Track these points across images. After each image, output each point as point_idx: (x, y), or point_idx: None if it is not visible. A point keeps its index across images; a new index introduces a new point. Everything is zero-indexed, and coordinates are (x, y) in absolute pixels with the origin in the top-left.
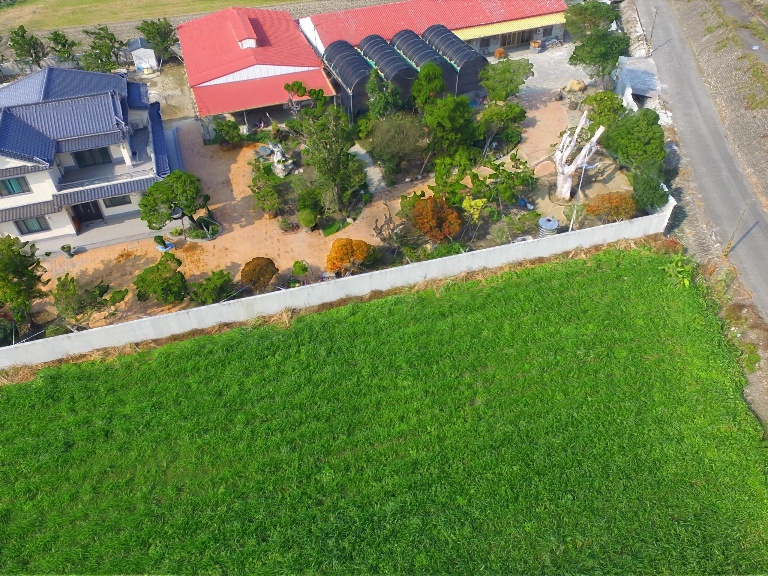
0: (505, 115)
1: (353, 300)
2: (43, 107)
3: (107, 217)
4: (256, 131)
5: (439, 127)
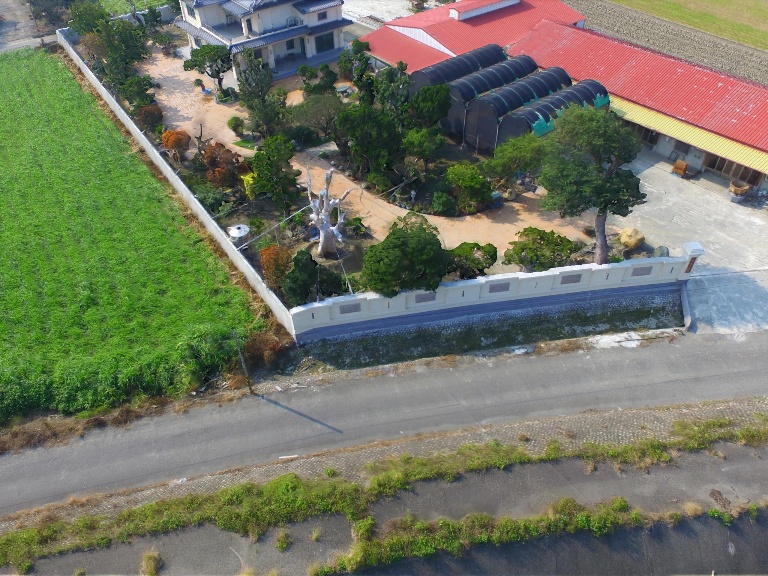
0: (461, 181)
1: (157, 171)
2: None
3: None
4: None
5: None
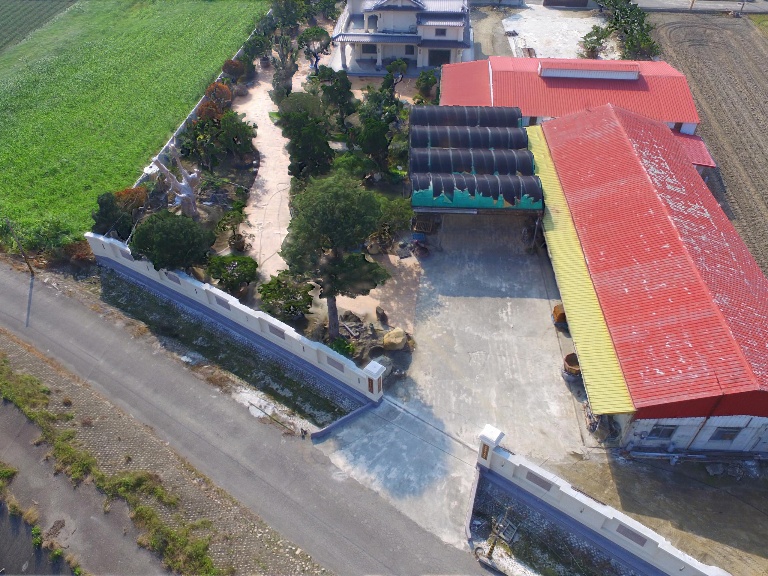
0: None
1: None
2: None
3: None
4: None
5: None
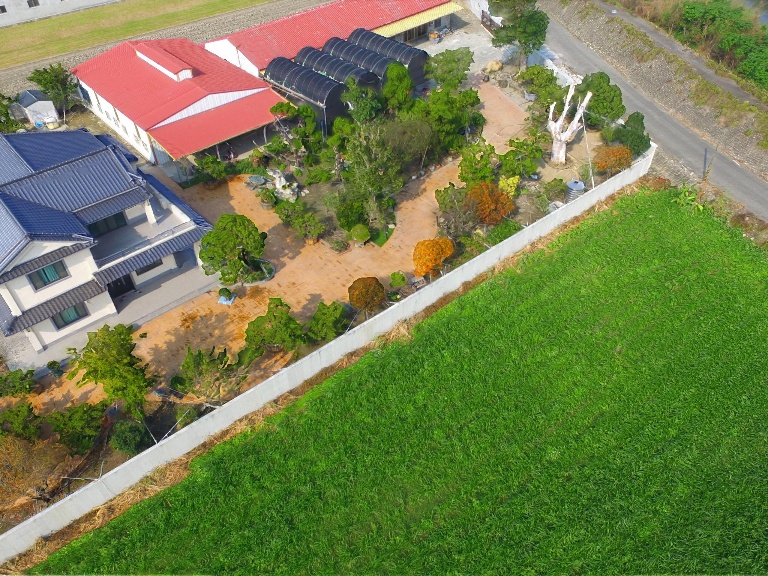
0: (465, 101)
1: (451, 297)
2: (39, 179)
3: (138, 286)
4: (231, 163)
5: (437, 121)
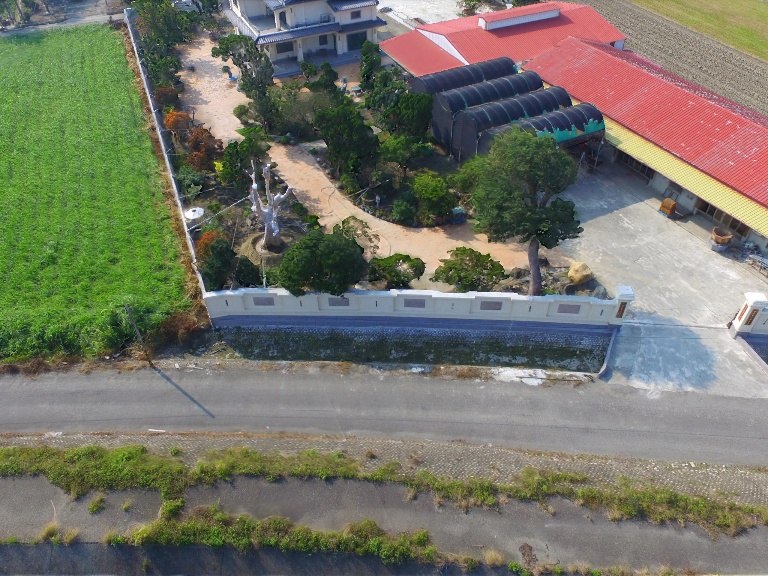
0: (424, 192)
1: None
2: None
3: None
4: None
5: None
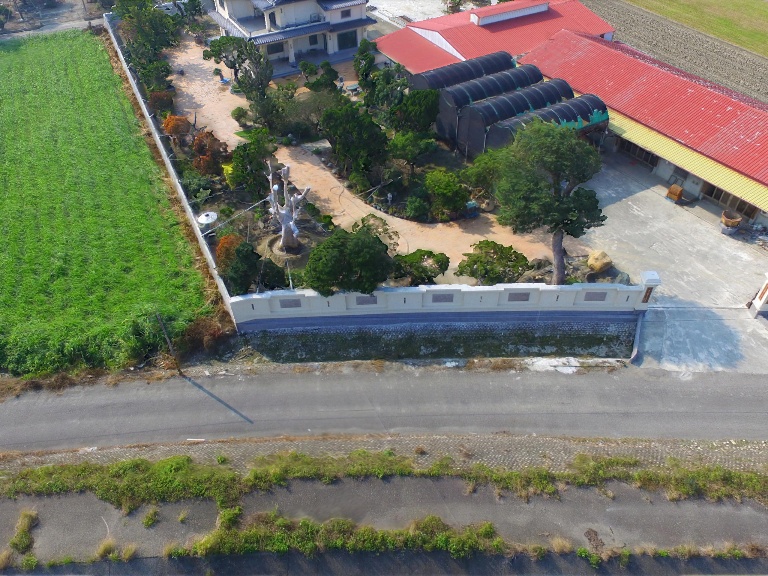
0: (437, 188)
1: None
2: None
3: None
4: None
5: None
